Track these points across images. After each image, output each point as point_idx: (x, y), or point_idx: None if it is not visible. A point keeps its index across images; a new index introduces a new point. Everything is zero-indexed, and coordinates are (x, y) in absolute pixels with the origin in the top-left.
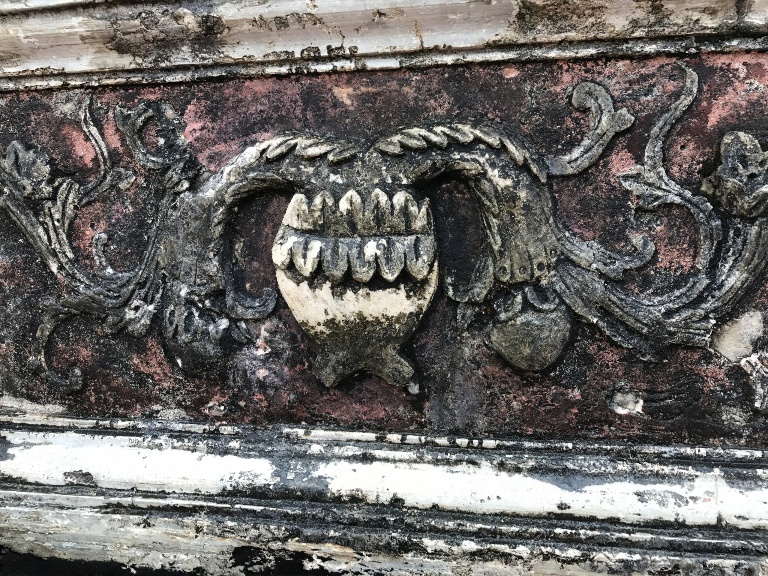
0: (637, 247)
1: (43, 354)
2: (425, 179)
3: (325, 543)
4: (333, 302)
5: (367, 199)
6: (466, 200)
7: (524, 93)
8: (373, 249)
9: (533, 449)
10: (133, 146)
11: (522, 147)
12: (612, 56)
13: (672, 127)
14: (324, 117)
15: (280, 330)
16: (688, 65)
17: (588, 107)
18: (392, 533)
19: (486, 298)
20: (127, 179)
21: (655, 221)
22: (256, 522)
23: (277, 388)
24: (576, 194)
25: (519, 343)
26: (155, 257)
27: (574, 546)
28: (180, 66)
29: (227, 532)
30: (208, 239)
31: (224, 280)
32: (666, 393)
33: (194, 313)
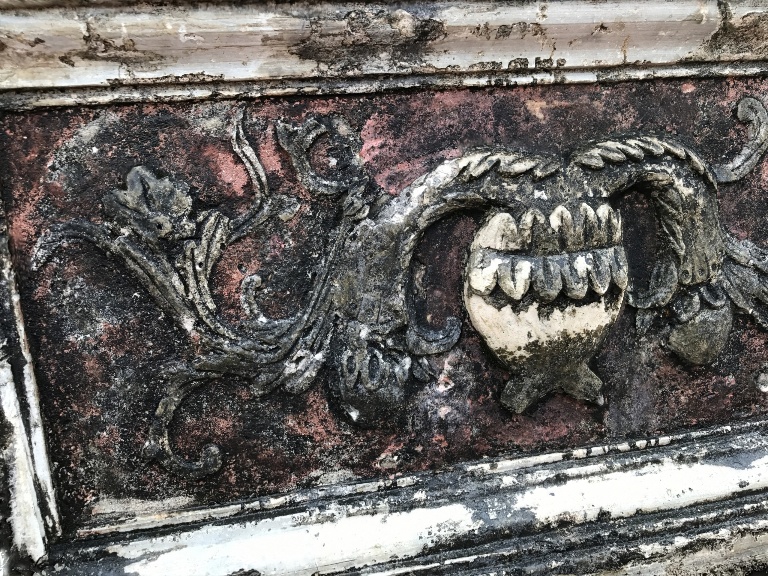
0: None
1: (166, 435)
2: (620, 191)
3: None
4: (538, 323)
5: (576, 214)
6: (645, 210)
7: (698, 107)
8: (584, 264)
9: (700, 438)
10: (301, 168)
11: None
12: None
13: None
14: (516, 131)
15: (464, 361)
16: None
17: (750, 120)
18: (610, 548)
19: (668, 302)
20: (290, 208)
21: None
22: (471, 574)
23: (458, 425)
24: (735, 199)
25: (699, 340)
26: (328, 297)
27: (761, 518)
28: (370, 75)
29: None
30: (395, 270)
31: (408, 314)
32: None
33: (378, 356)
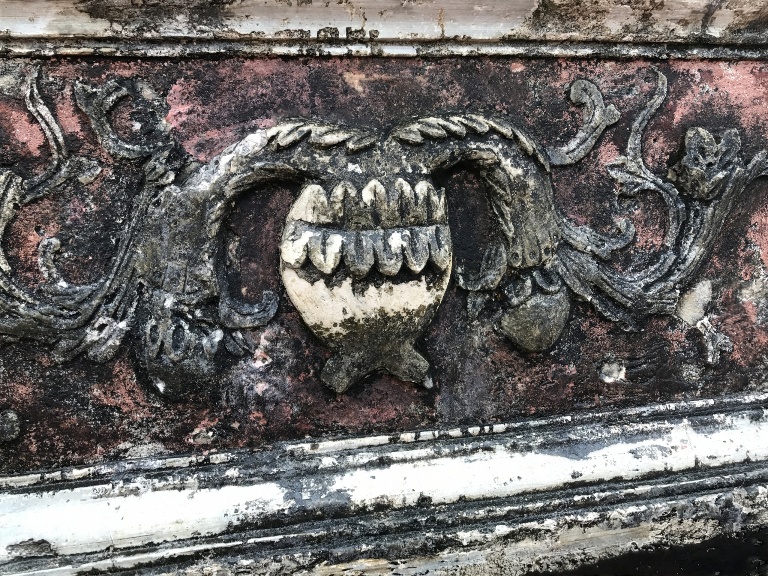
0: (621, 229)
1: None
2: (443, 169)
3: (357, 560)
4: (353, 299)
5: (391, 189)
6: (475, 190)
7: (528, 87)
8: (399, 240)
9: (538, 427)
10: (100, 130)
11: (530, 138)
12: (603, 57)
13: (648, 123)
14: (333, 104)
15: (282, 337)
16: (659, 69)
17: (584, 102)
18: (426, 534)
19: (499, 285)
20: (90, 171)
21: (633, 206)
22: (275, 554)
23: (277, 402)
24: (571, 183)
25: (530, 325)
26: (130, 263)
27: (591, 510)
28: (170, 38)
29: (242, 573)
30: (201, 239)
31: (218, 285)
32: (643, 359)
33: (183, 326)
